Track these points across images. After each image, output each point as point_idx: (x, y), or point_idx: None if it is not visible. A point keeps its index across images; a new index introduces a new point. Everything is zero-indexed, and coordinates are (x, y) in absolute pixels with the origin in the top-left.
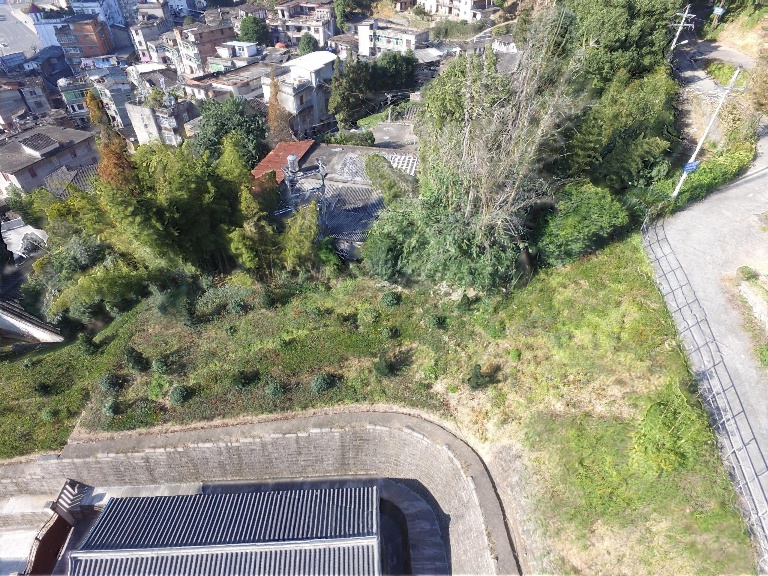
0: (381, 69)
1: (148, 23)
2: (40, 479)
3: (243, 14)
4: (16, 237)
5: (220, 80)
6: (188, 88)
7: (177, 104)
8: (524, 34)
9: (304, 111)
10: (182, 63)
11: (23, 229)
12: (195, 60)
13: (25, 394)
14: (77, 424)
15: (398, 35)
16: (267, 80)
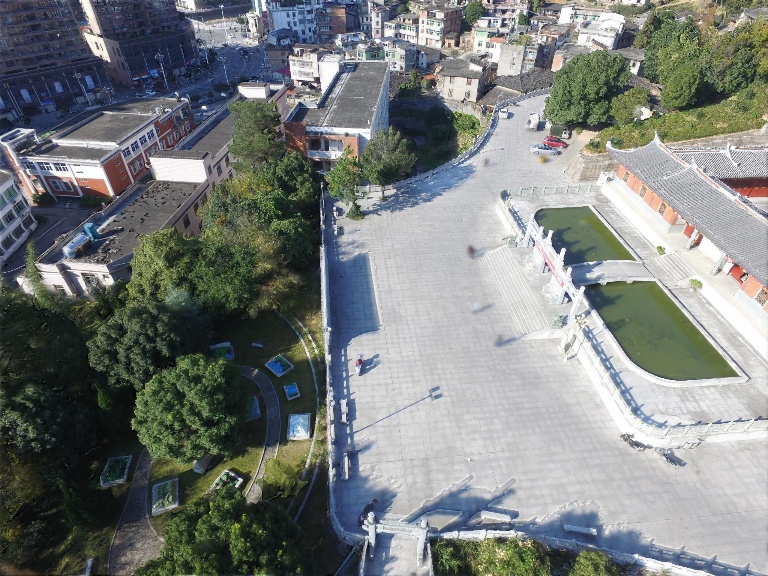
0: (662, 22)
1: (383, 8)
2: (761, 136)
3: (454, 2)
4: (525, 105)
5: (546, 32)
6: (533, 36)
7: (537, 44)
8: (738, 2)
9: (612, 49)
10: (417, 37)
11: (522, 102)
12: (439, 33)
13: (736, 111)
14: (766, 118)
15: (597, 13)
16: (586, 30)
